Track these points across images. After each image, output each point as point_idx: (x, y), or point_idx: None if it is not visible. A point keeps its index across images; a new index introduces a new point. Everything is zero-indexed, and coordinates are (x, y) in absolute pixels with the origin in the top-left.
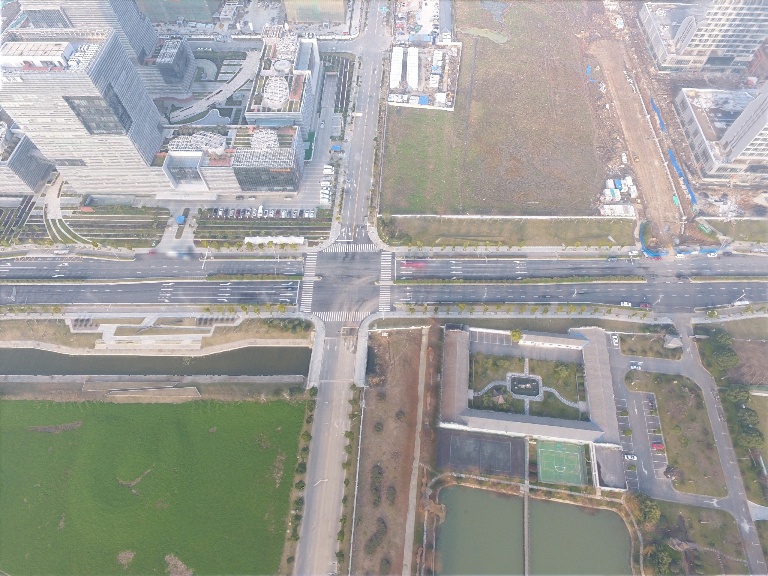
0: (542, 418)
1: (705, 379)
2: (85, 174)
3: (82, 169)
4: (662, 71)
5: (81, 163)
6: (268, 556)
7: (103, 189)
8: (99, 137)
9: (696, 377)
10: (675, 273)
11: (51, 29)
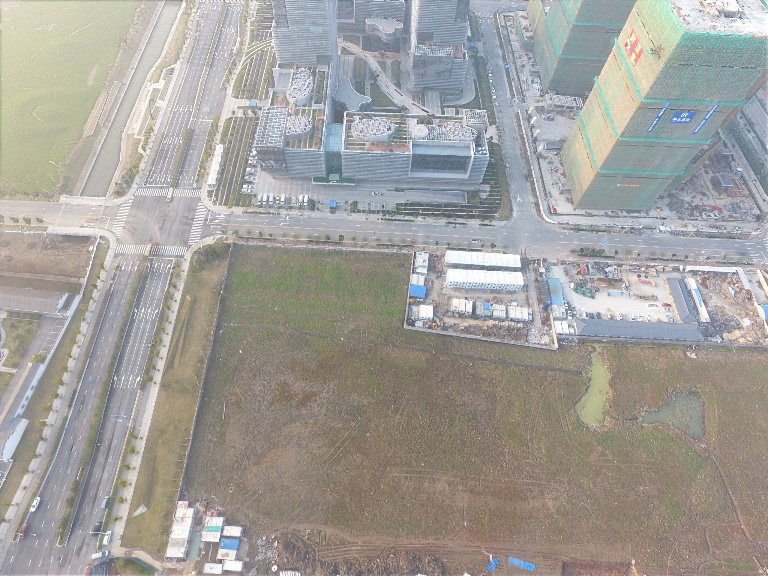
0: None
1: None
2: None
3: None
4: None
5: None
6: None
7: None
8: None
9: None
10: None
11: None
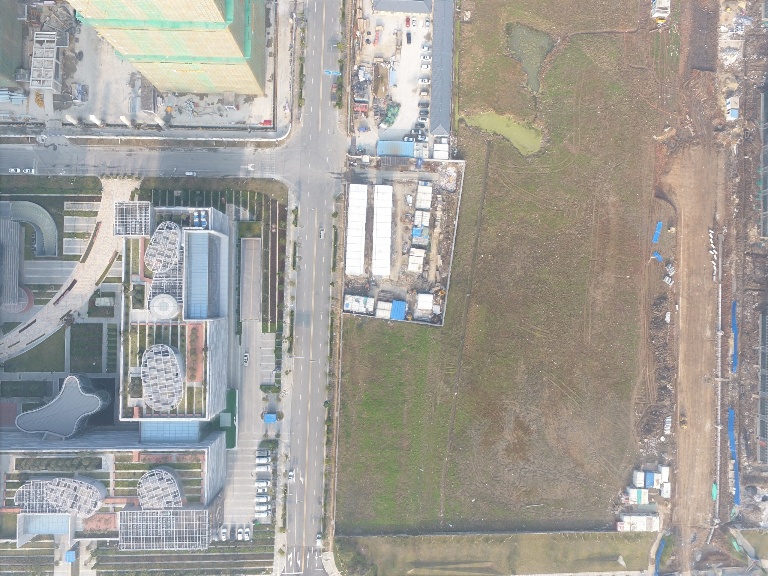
0: None
1: None
2: None
3: None
4: (767, 237)
5: None
6: None
7: None
8: None
9: None
10: None
11: None
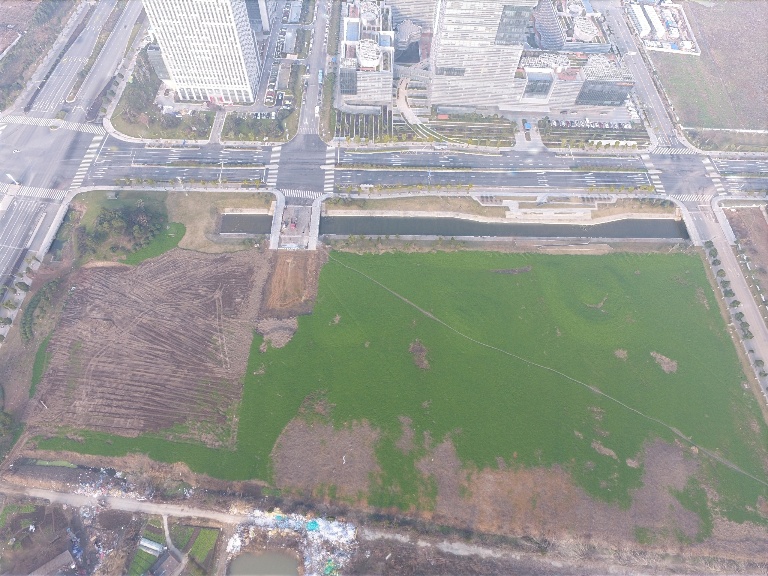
0: None
1: None
2: (454, 84)
3: (457, 79)
4: None
5: (457, 73)
6: (727, 352)
7: (456, 100)
8: (499, 47)
9: None
10: None
11: None
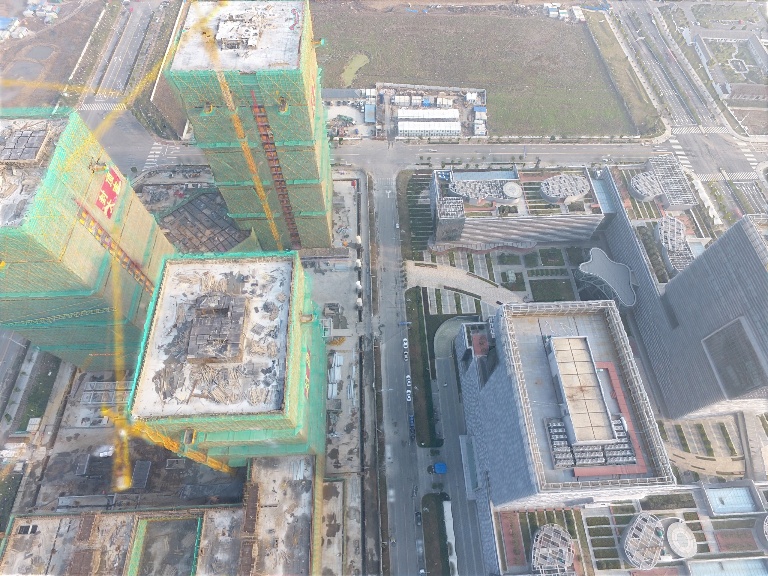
0: (761, 56)
1: (688, 2)
2: None
3: None
4: None
5: None
6: None
7: None
8: None
9: (689, 5)
10: (618, 1)
11: None
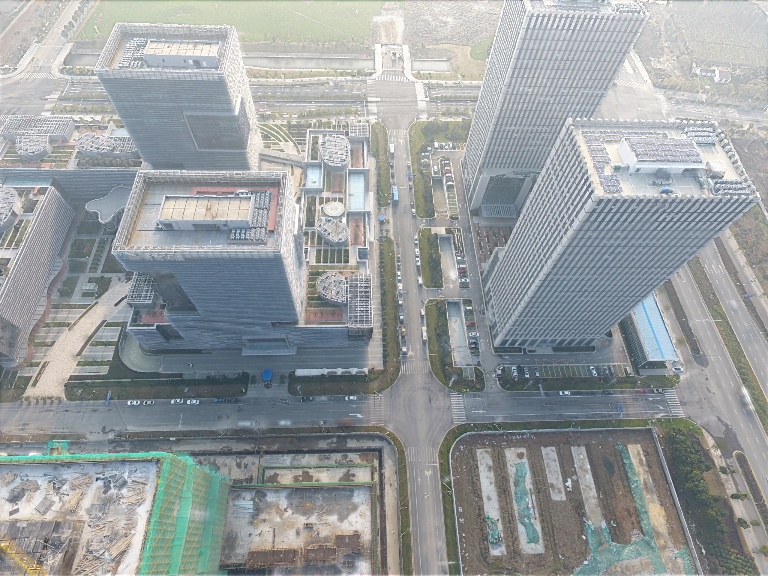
0: None
1: None
2: None
3: None
4: None
5: None
6: None
7: None
8: None
9: None
10: None
11: (169, 70)
